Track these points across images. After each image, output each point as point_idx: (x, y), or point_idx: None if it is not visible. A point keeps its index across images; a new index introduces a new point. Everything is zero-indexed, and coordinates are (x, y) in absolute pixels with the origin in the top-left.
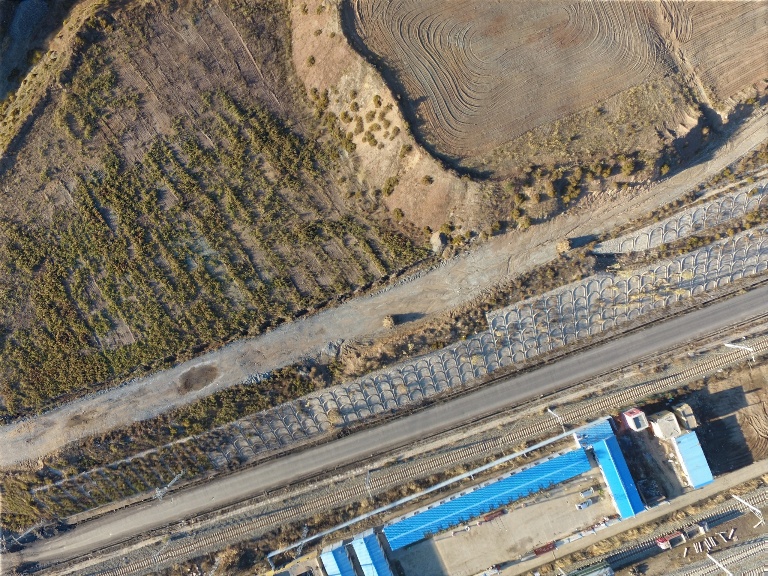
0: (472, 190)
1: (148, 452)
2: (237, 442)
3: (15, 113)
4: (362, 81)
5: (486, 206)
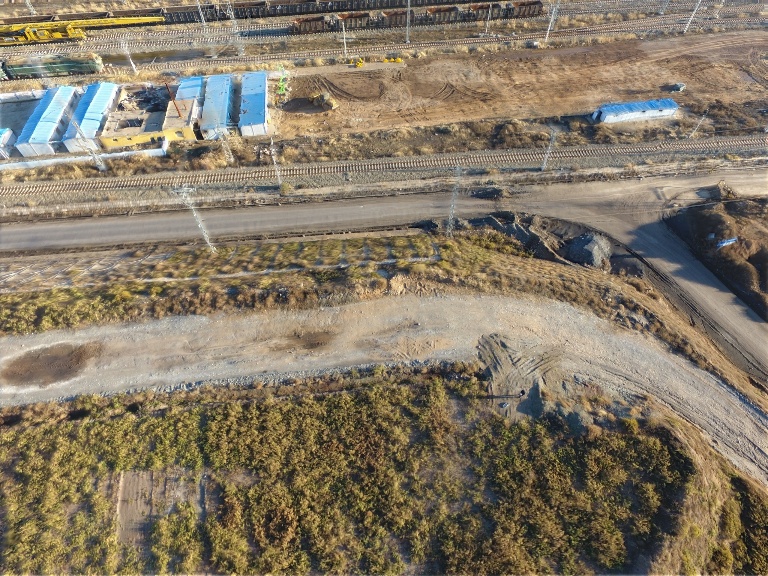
0: None
1: (229, 276)
2: None
3: None
4: None
5: None
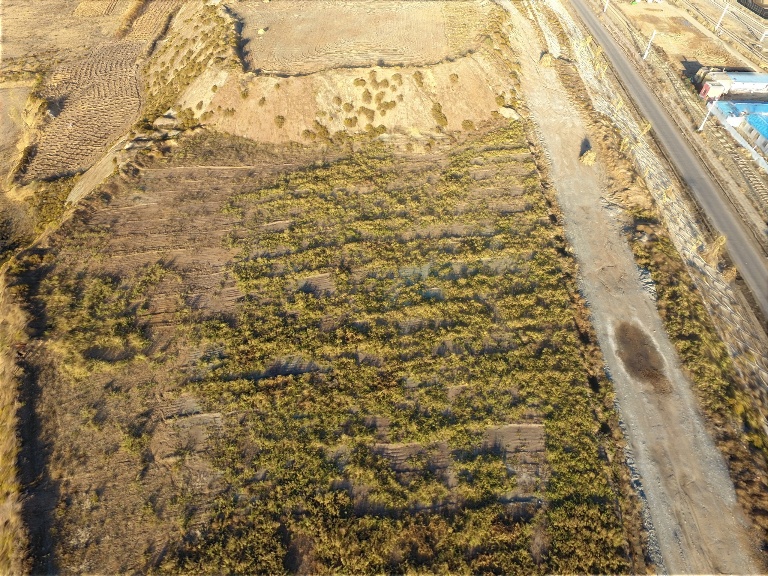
0: (479, 59)
1: None
2: (765, 382)
3: None
4: (333, 85)
5: (496, 64)
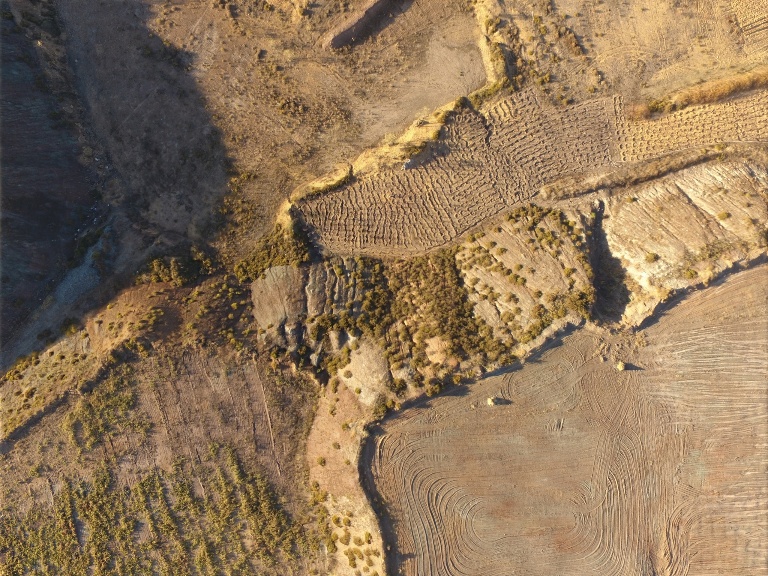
0: None
1: None
2: None
3: (29, 395)
4: (361, 513)
5: None
